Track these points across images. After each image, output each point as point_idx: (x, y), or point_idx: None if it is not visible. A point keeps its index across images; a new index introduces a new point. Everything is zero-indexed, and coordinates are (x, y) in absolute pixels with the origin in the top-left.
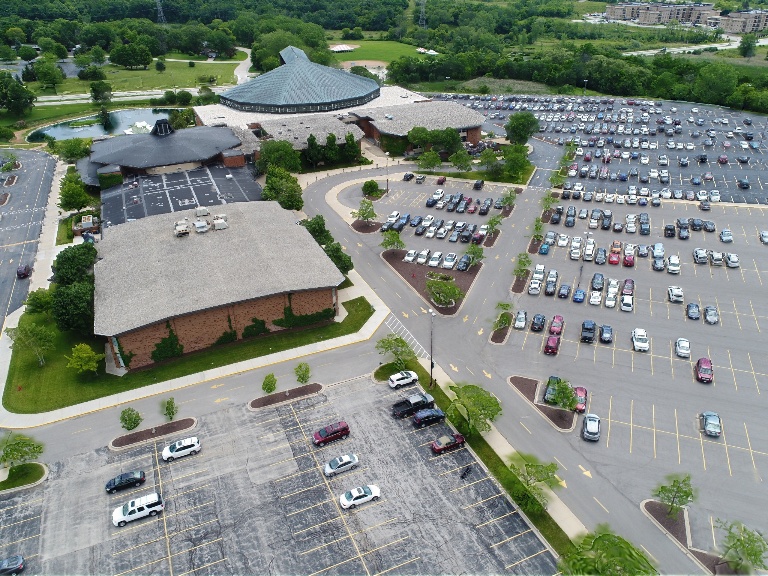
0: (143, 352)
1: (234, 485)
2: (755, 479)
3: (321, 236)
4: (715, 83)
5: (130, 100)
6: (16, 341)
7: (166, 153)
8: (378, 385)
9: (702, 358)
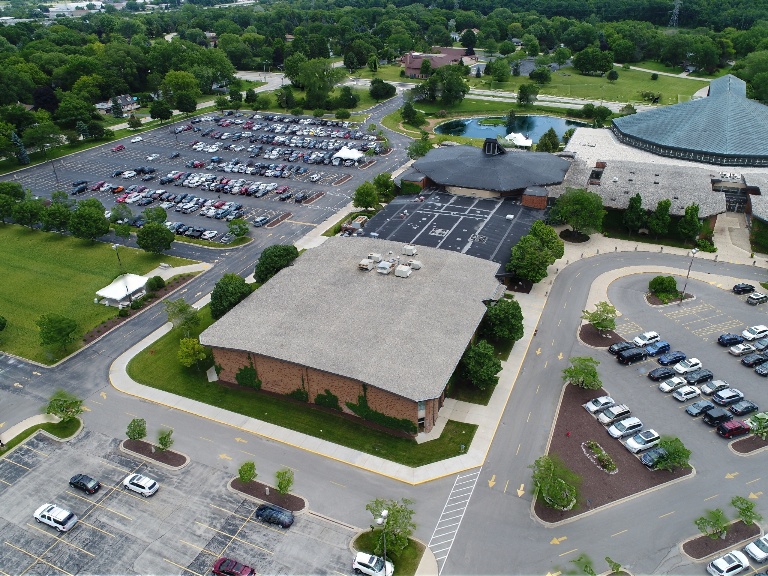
0: (230, 370)
1: (122, 553)
2: None
3: (505, 327)
4: None
5: (553, 106)
6: None
7: (473, 174)
8: (348, 551)
9: None
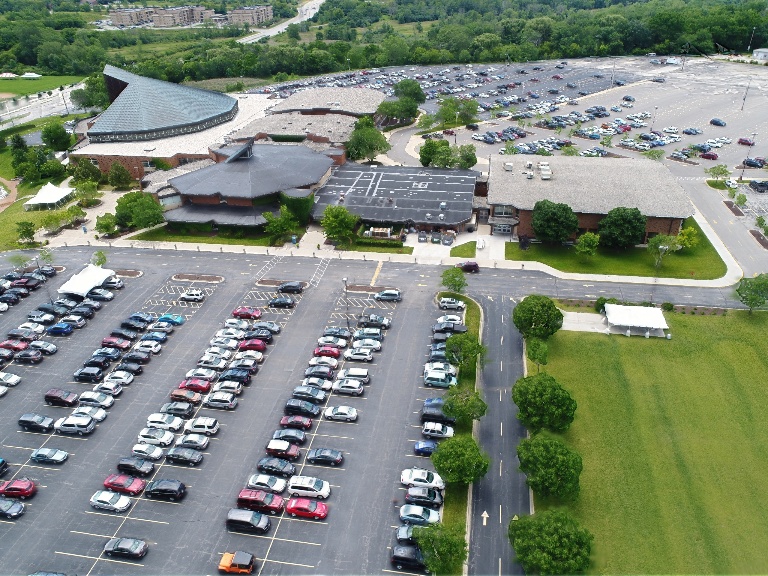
0: None
1: None
2: None
3: None
4: (396, 51)
5: None
6: (670, 246)
7: (300, 167)
8: None
9: (741, 138)
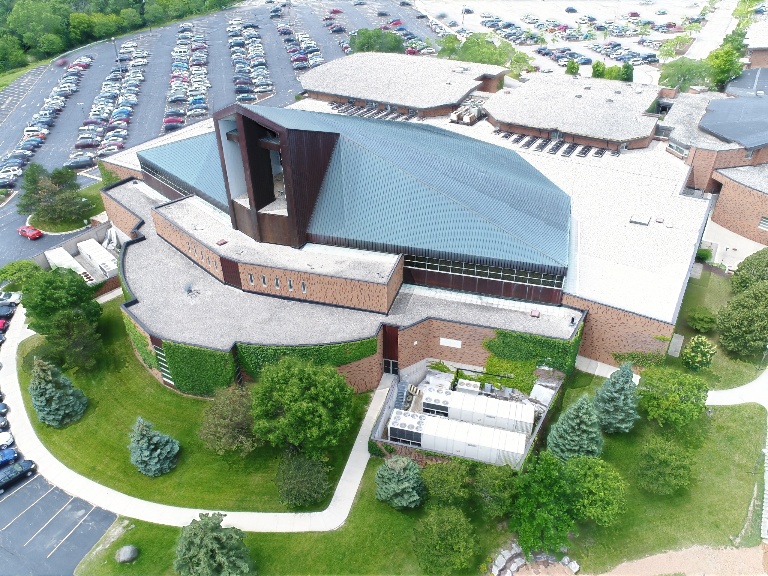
0: None
1: None
2: (676, 8)
3: None
4: (45, 25)
5: None
6: None
7: None
8: None
9: (631, 12)
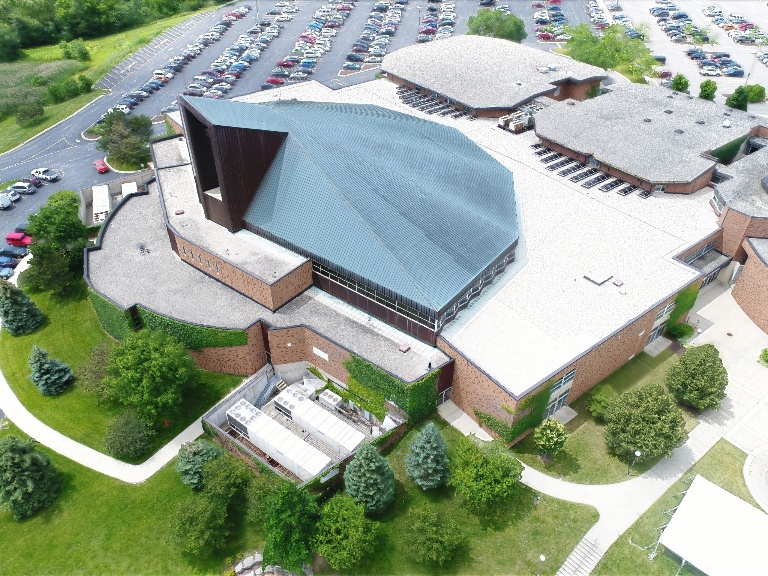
0: None
1: None
2: None
3: None
4: None
5: None
6: None
7: None
8: None
9: None
